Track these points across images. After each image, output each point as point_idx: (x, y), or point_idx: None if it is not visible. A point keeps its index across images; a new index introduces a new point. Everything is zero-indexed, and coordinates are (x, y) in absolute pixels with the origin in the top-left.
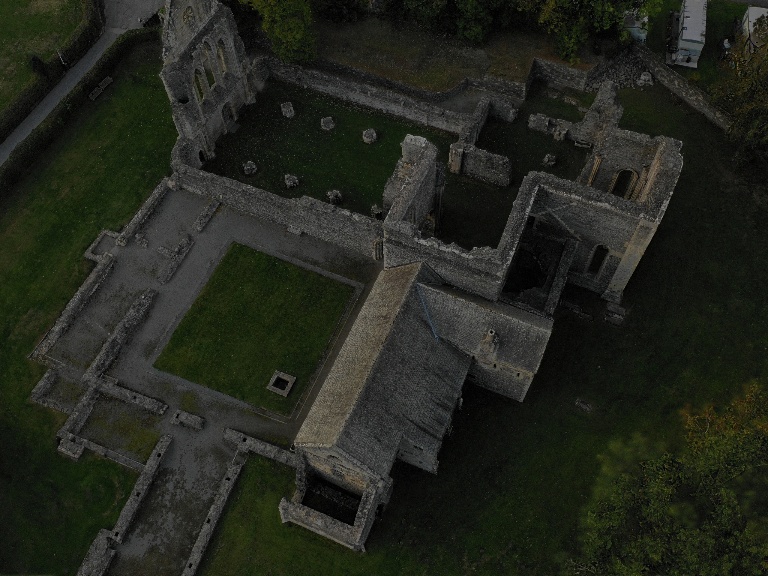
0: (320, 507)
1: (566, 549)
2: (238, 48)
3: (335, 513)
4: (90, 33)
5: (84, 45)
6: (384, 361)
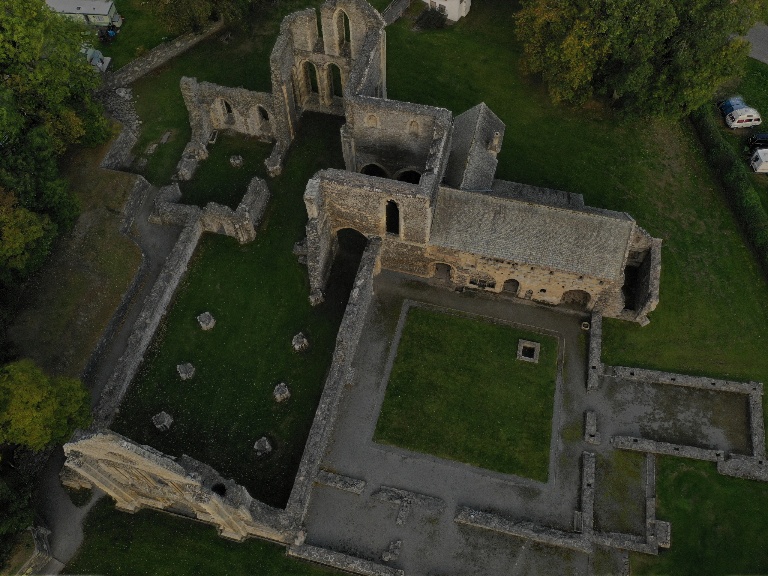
0: (627, 297)
1: (596, 142)
2: None
3: (627, 285)
4: None
5: None
6: None
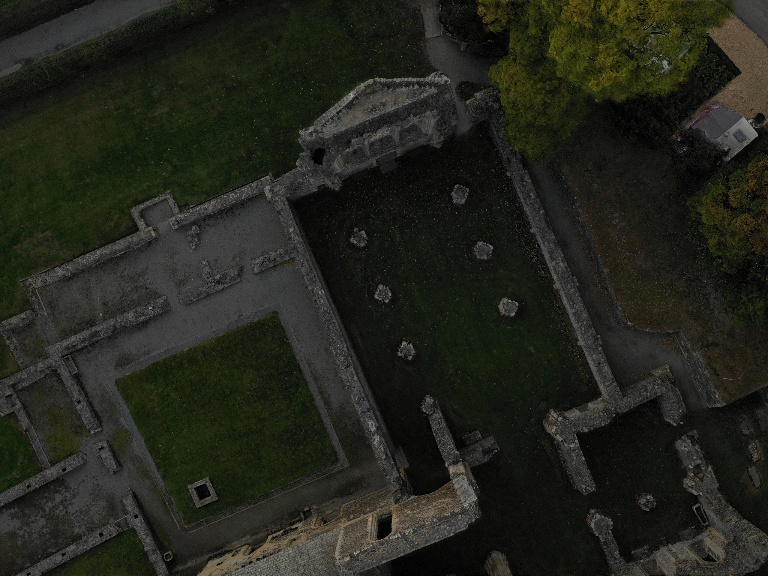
0: None
1: None
2: (440, 125)
3: None
4: None
5: None
6: None
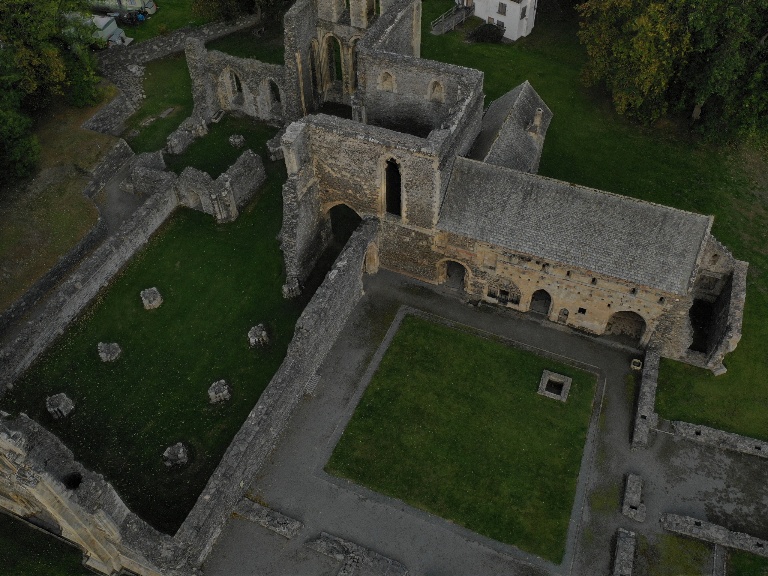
0: (696, 336)
1: (668, 162)
2: None
3: (698, 322)
4: None
5: None
6: None
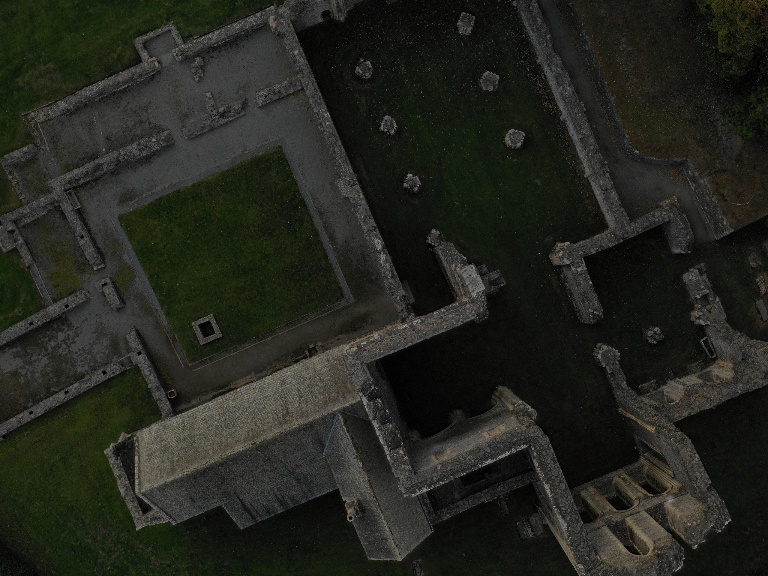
0: None
1: None
2: None
3: None
4: None
5: None
6: (245, 455)
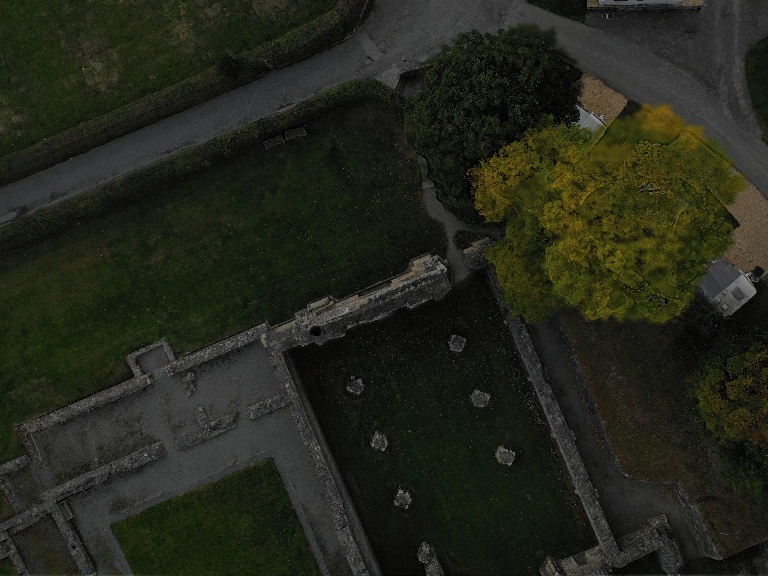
0: None
1: None
2: None
3: None
4: (329, 38)
5: (311, 49)
6: None
